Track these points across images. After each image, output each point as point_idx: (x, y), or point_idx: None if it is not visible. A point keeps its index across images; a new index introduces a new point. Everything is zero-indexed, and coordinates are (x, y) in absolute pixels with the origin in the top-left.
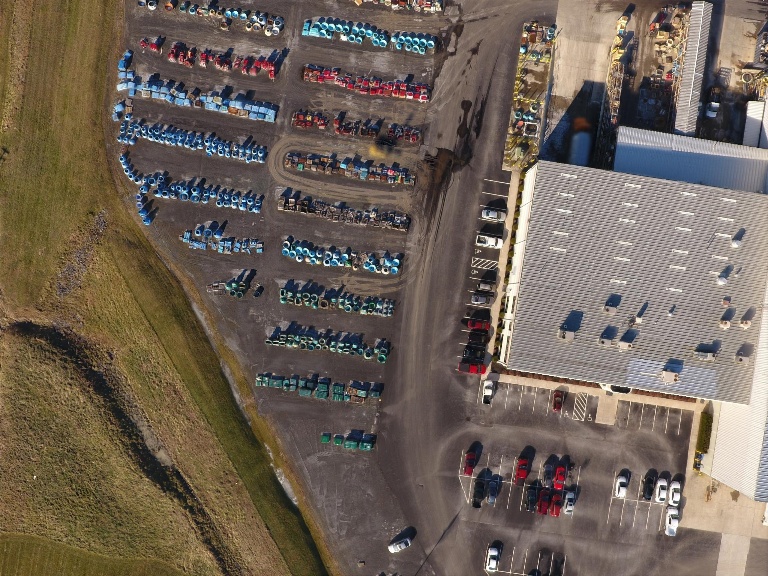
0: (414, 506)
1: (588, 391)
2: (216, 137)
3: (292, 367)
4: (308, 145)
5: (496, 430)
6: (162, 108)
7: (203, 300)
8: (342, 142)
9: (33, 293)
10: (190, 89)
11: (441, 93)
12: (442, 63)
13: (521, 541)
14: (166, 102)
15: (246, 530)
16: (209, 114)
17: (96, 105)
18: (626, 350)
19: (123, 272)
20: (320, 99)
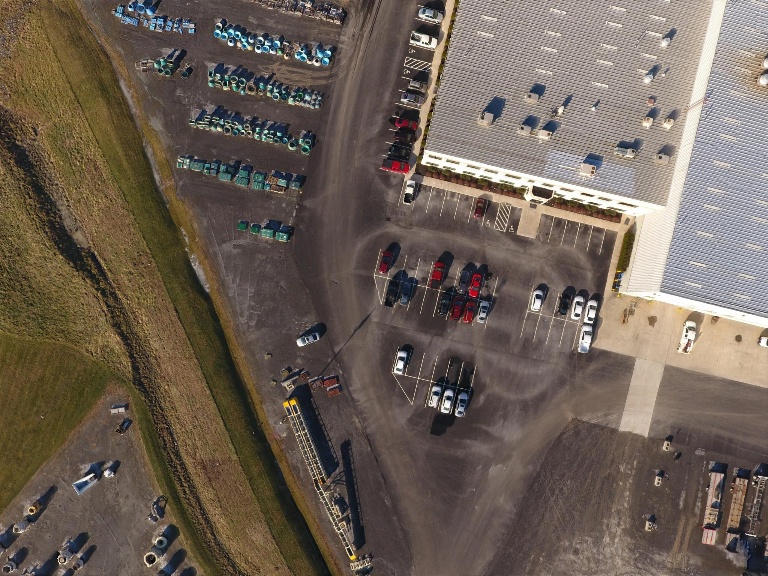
0: (326, 302)
1: (512, 202)
2: None
3: (215, 152)
4: None
5: (416, 233)
6: None
7: (131, 77)
8: None
9: None
10: None
11: None
12: None
13: (432, 347)
14: None
15: (156, 314)
16: None
17: None
18: (546, 141)
19: (52, 41)
20: None
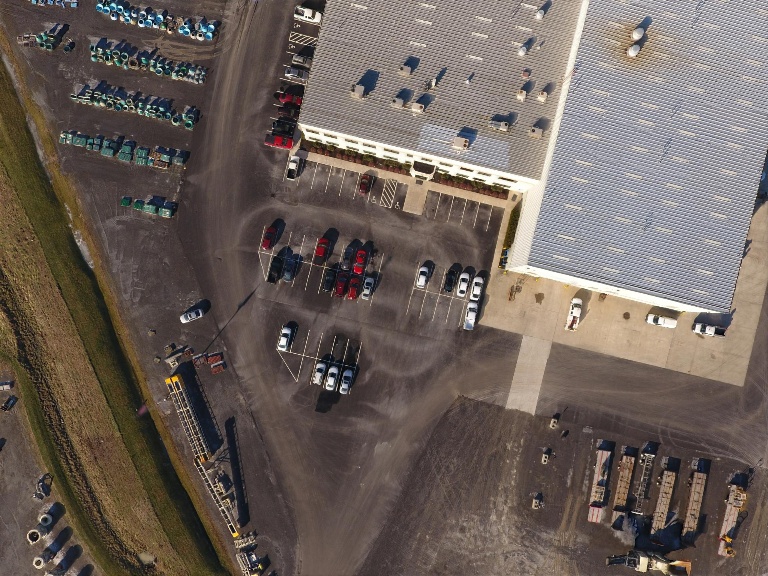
0: (210, 279)
1: (398, 178)
2: None
3: (98, 127)
4: None
5: (300, 209)
6: None
7: (13, 52)
8: None
9: None
10: None
11: None
12: None
13: (317, 324)
14: None
15: (40, 291)
16: None
17: None
18: (420, 115)
19: None
20: None
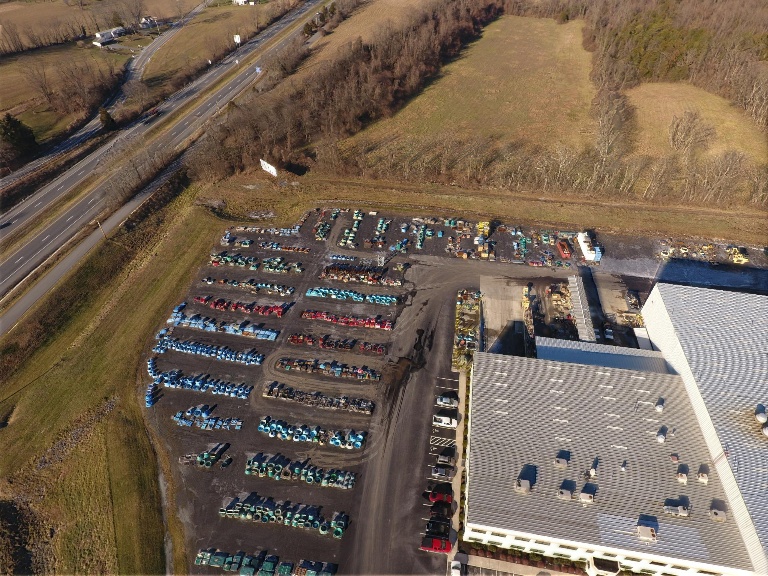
0: None
1: None
2: (228, 349)
3: (240, 542)
4: (297, 354)
5: None
6: (194, 332)
7: (172, 471)
8: (324, 353)
9: (15, 466)
10: (219, 322)
11: (401, 325)
12: (402, 310)
13: None
14: (199, 329)
15: None
16: (227, 336)
17: (147, 330)
18: (590, 505)
19: (109, 444)
20: (311, 328)
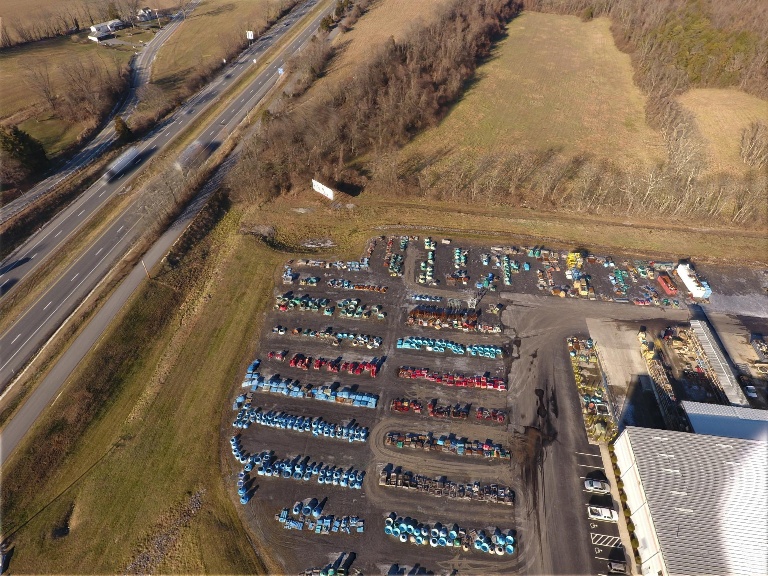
0: None
1: None
2: (322, 421)
3: None
4: (406, 426)
5: None
6: (277, 399)
7: None
8: (436, 423)
9: None
10: (304, 385)
11: (515, 384)
12: (511, 364)
13: None
14: (282, 394)
15: None
16: (318, 403)
17: (221, 398)
18: None
19: (206, 559)
20: (414, 390)
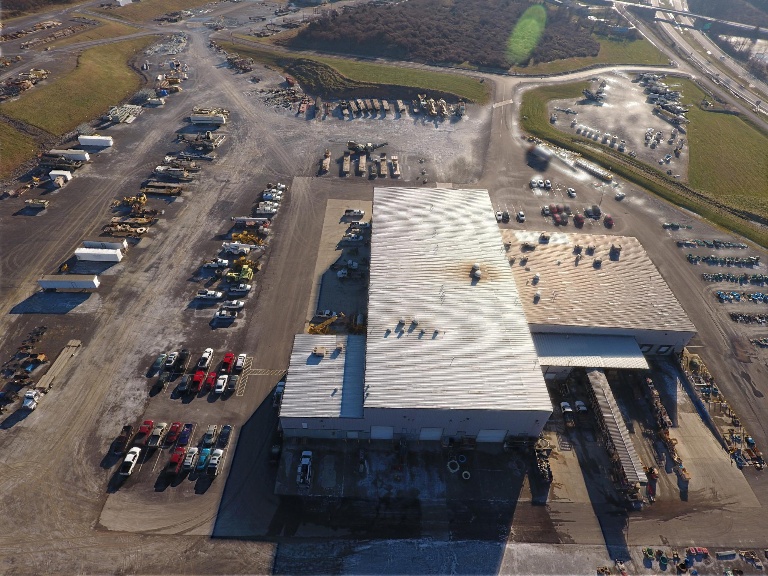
0: (624, 207)
1: None
2: None
3: (734, 251)
4: None
5: (603, 233)
6: None
7: None
8: None
9: None
10: None
11: None
12: None
13: None
14: None
15: None
16: None
17: None
18: None
19: None
20: None
